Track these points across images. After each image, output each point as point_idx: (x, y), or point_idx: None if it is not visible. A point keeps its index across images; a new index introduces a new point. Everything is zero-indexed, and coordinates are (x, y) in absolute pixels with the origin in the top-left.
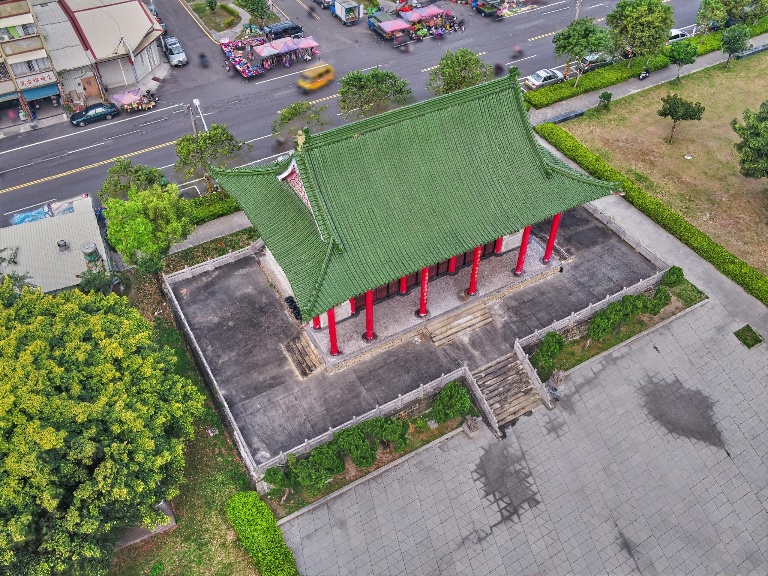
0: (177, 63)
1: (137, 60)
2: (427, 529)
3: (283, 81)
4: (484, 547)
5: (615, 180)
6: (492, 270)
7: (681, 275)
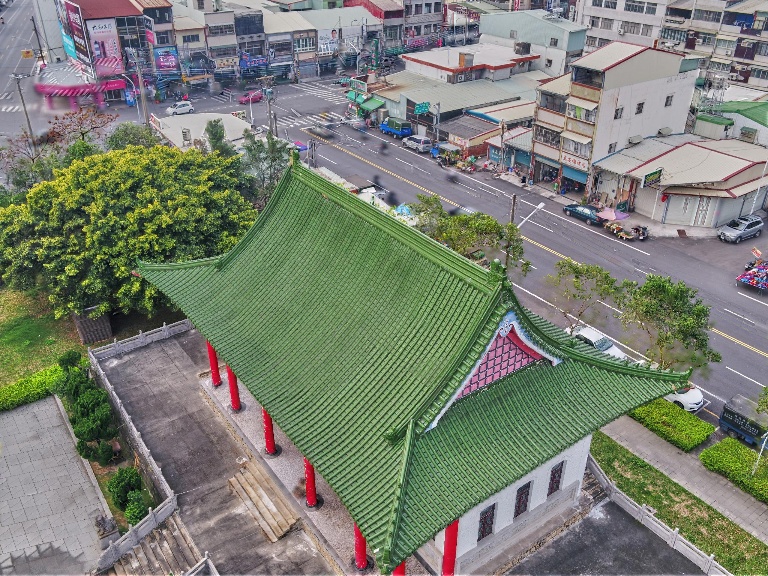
0: (721, 235)
1: (678, 203)
2: None
3: (766, 311)
4: None
5: None
6: None
7: None
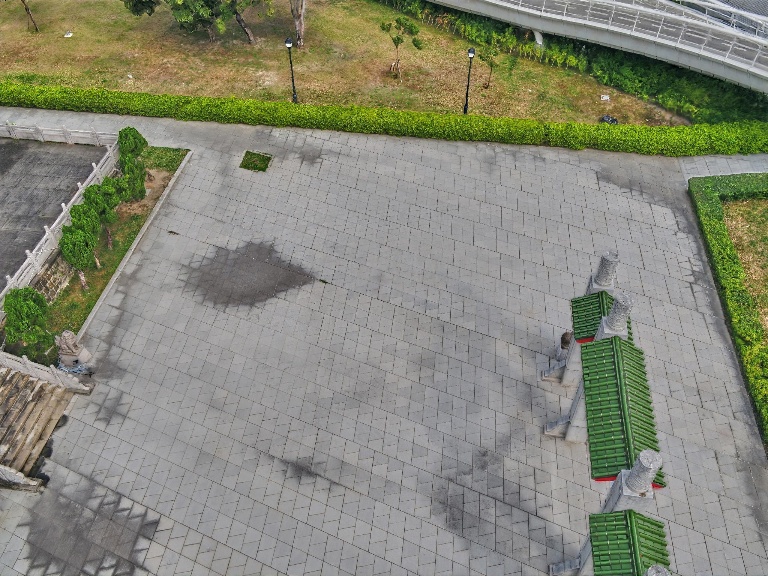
0: None
1: None
2: None
3: None
4: None
5: None
6: None
7: (138, 135)
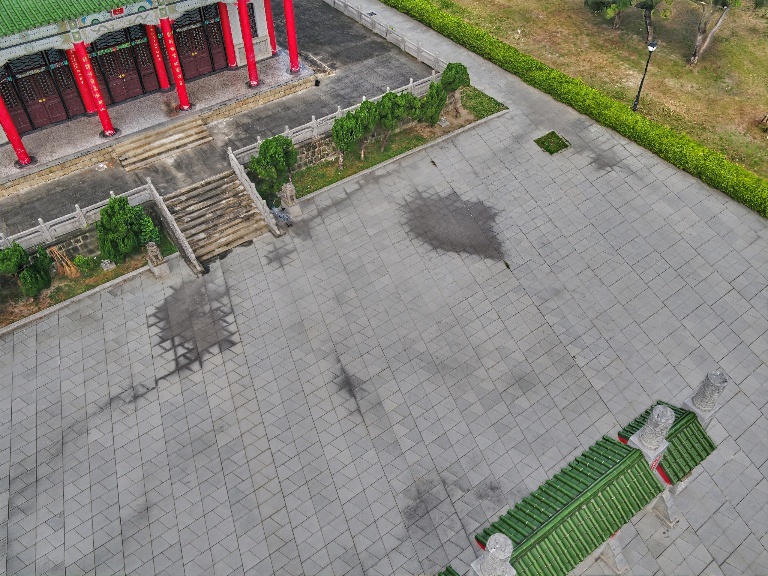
0: None
1: None
2: (60, 391)
3: None
4: (139, 406)
5: (411, 4)
6: (220, 84)
7: (464, 73)
